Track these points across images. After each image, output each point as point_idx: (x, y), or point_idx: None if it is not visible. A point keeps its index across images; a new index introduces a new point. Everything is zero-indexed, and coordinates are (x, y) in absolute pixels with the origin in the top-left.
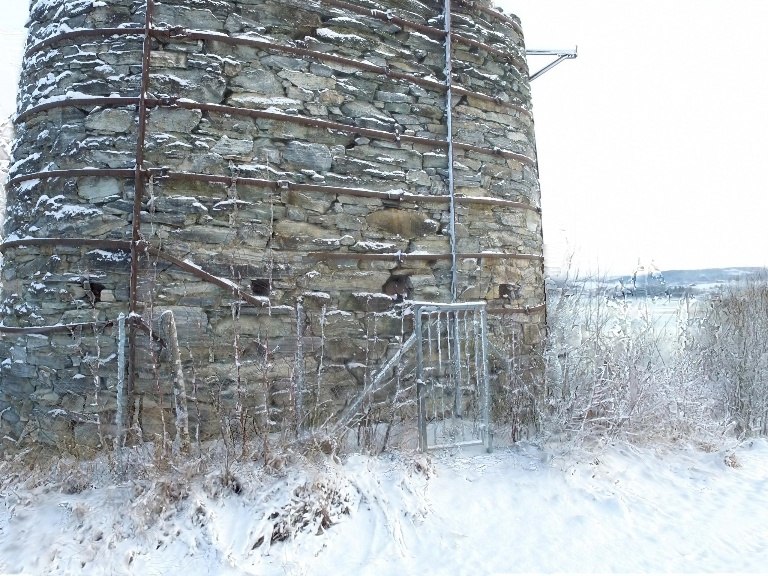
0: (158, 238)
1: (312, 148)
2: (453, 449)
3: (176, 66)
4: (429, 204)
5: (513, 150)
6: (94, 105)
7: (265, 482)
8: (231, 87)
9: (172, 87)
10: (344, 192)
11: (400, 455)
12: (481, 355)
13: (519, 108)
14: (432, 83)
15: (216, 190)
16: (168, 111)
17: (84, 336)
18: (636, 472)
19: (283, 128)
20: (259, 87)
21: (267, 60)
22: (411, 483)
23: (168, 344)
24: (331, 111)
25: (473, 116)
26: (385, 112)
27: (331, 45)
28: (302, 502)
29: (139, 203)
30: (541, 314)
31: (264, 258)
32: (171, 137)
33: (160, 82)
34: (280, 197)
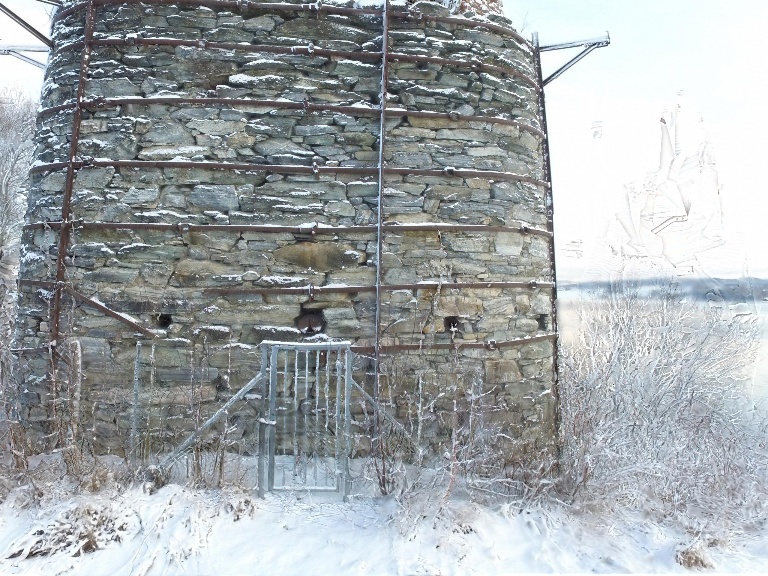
0: (76, 279)
1: (217, 190)
2: (302, 492)
3: (99, 131)
4: (352, 235)
5: (478, 167)
6: (46, 170)
7: (62, 501)
8: (141, 143)
9: (95, 149)
10: (249, 229)
11: (221, 492)
12: (343, 397)
13: (491, 119)
14: (361, 109)
15: (123, 236)
16: (89, 170)
17: (31, 359)
18: (518, 550)
19: (188, 174)
20: (169, 139)
21: (176, 114)
22: (197, 522)
23: (72, 370)
24: (240, 153)
25: (416, 137)
26: (304, 146)
27: (243, 89)
28: (69, 524)
29: (65, 250)
30: (524, 349)
31: (163, 295)
32: (90, 193)
33: (86, 146)
34: (182, 238)
